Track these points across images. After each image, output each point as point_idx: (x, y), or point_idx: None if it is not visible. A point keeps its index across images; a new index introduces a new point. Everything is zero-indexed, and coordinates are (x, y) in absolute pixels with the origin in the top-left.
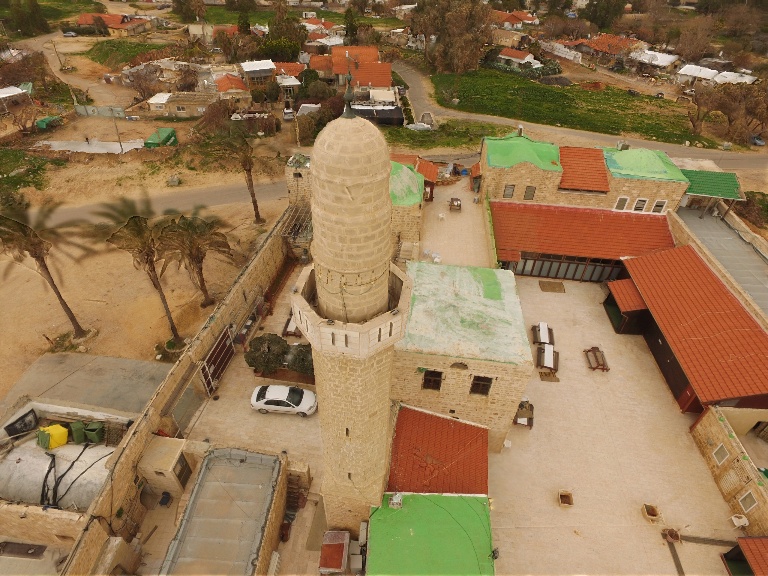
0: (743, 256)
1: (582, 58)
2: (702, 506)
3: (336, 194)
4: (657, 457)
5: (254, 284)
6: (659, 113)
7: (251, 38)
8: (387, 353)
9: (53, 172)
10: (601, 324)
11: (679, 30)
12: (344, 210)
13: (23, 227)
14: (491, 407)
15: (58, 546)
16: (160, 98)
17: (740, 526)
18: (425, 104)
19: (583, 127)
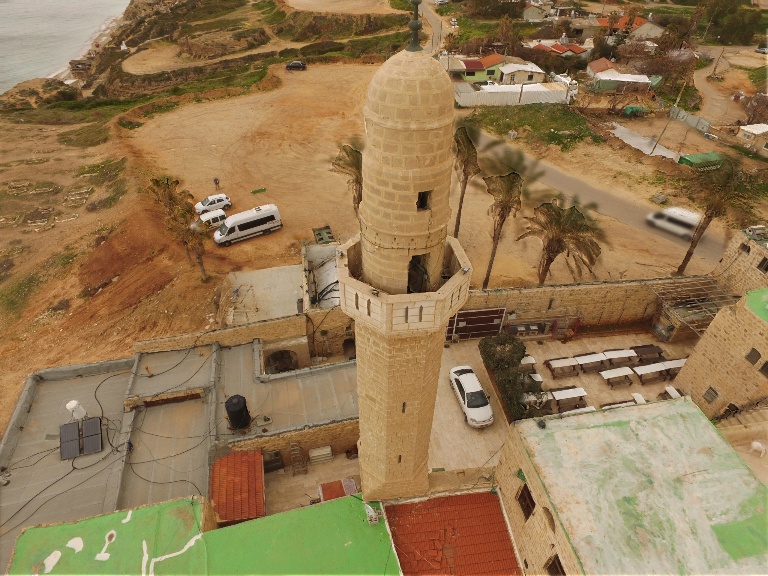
0: None
1: None
2: None
3: None
4: None
5: (574, 305)
6: None
7: None
8: (385, 344)
9: (585, 144)
10: None
11: None
12: None
13: (471, 147)
14: None
15: None
16: (759, 128)
17: None
18: None
19: None
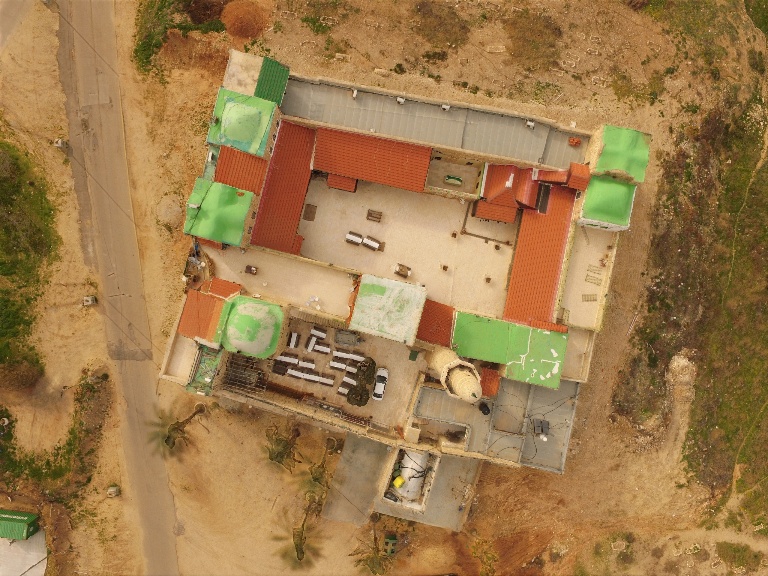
0: (332, 99)
1: None
2: (453, 210)
3: None
4: (431, 216)
5: None
6: None
7: None
8: None
9: None
10: (347, 198)
11: None
12: None
13: (299, 541)
14: None
15: None
16: None
17: None
18: None
19: None
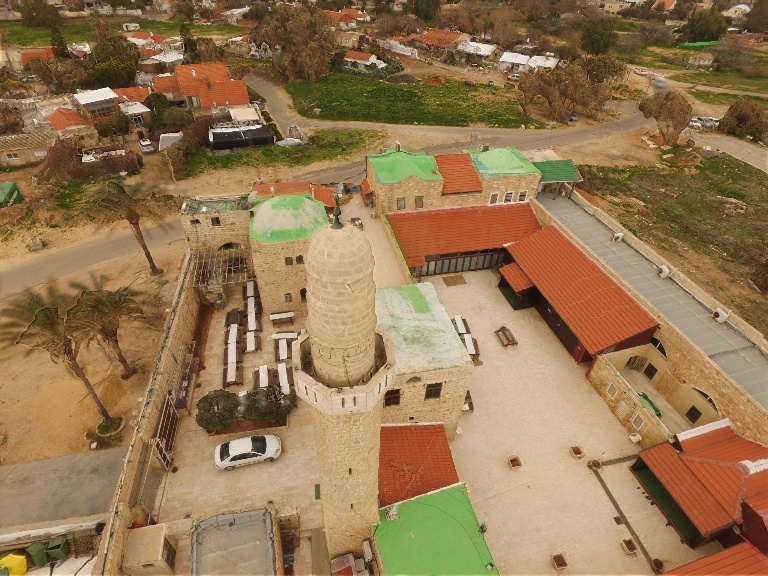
0: (591, 227)
1: None
2: (609, 435)
3: (338, 291)
4: (570, 406)
5: (180, 343)
6: (494, 101)
7: (74, 63)
8: None
9: None
10: (501, 305)
11: (492, 22)
12: (345, 301)
13: None
14: (443, 406)
15: None
16: None
17: (637, 442)
18: (287, 117)
19: (437, 123)
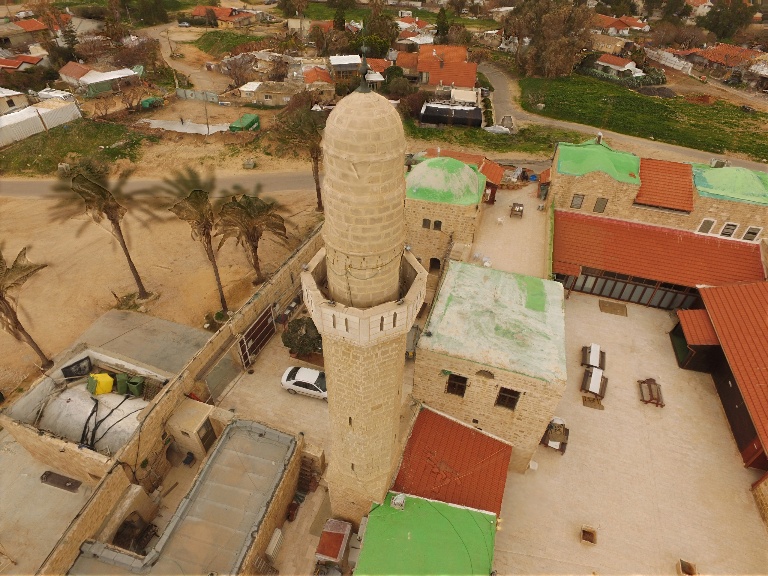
0: None
1: (693, 69)
2: (752, 575)
3: (343, 171)
4: (705, 511)
5: None
6: None
7: (344, 33)
8: (393, 345)
9: (147, 147)
10: (663, 355)
11: None
12: (350, 188)
13: (103, 191)
14: (517, 423)
15: (91, 484)
16: (251, 86)
17: None
18: (508, 107)
19: (680, 142)
